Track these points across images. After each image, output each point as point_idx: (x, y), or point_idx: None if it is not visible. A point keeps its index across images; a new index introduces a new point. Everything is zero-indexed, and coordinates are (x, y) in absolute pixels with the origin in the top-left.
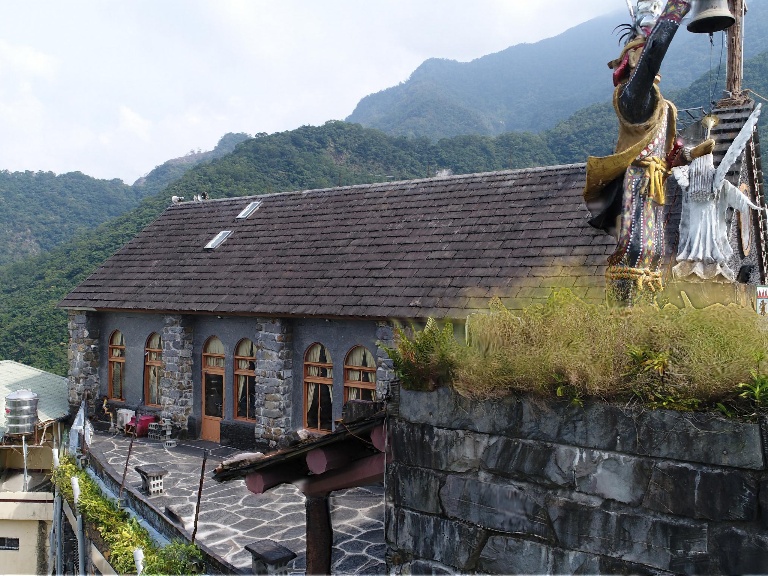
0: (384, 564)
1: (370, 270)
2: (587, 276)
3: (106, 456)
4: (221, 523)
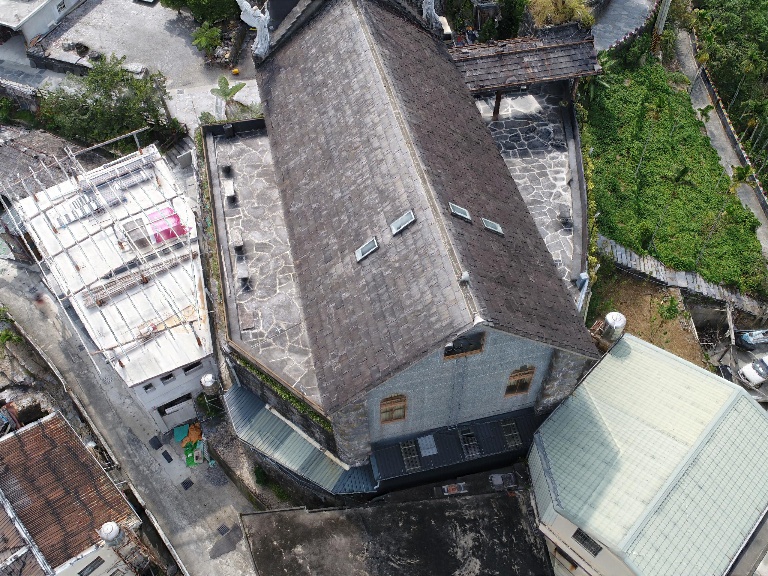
0: (522, 133)
1: (465, 121)
2: (435, 50)
3: (567, 282)
4: (551, 180)
